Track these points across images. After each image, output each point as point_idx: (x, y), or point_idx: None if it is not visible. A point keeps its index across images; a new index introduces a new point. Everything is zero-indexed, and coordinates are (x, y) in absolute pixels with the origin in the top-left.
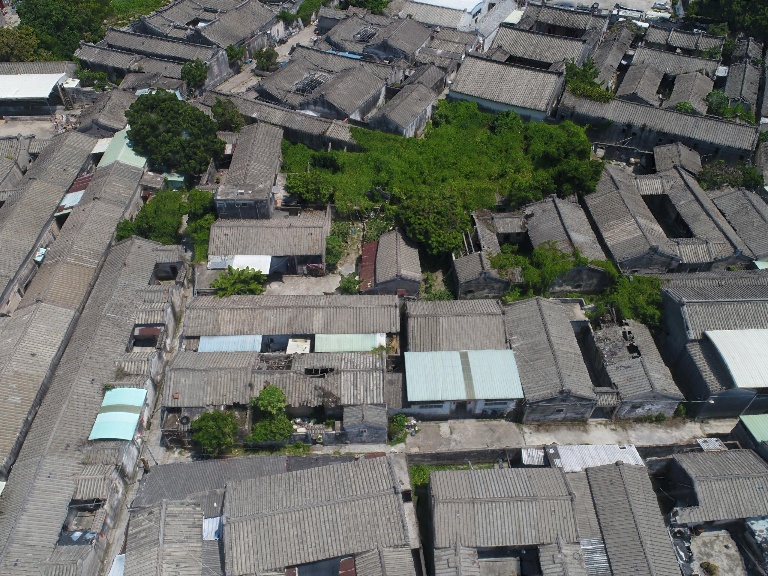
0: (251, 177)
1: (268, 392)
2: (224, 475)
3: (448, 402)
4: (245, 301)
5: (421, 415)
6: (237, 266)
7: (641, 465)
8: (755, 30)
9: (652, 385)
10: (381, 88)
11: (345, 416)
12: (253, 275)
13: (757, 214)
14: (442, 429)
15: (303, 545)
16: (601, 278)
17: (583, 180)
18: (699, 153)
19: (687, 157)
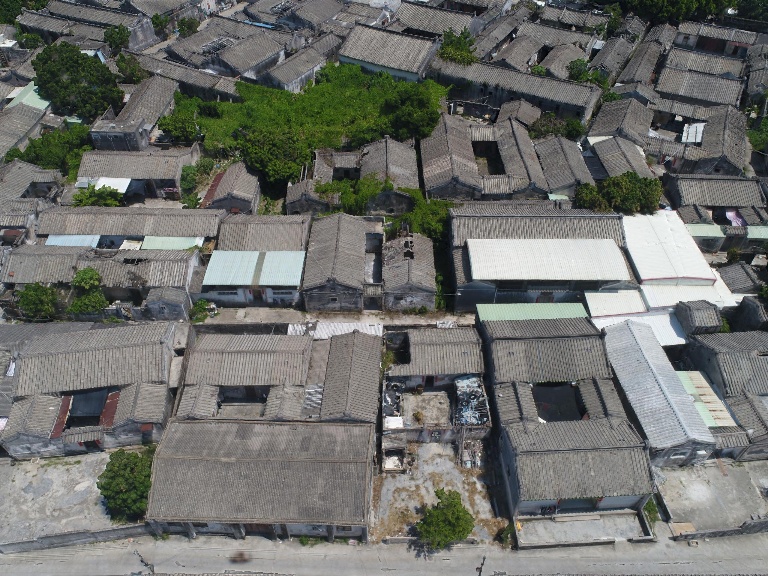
0: (134, 118)
1: (84, 271)
2: (37, 332)
3: (241, 289)
4: (94, 210)
5: (222, 302)
6: (100, 186)
7: (376, 335)
8: (642, 10)
9: (409, 279)
10: (279, 52)
11: (149, 295)
12: (109, 192)
13: (563, 156)
14: (238, 314)
15: (77, 377)
16: (409, 203)
17: (417, 125)
18: (544, 110)
19: (526, 111)
